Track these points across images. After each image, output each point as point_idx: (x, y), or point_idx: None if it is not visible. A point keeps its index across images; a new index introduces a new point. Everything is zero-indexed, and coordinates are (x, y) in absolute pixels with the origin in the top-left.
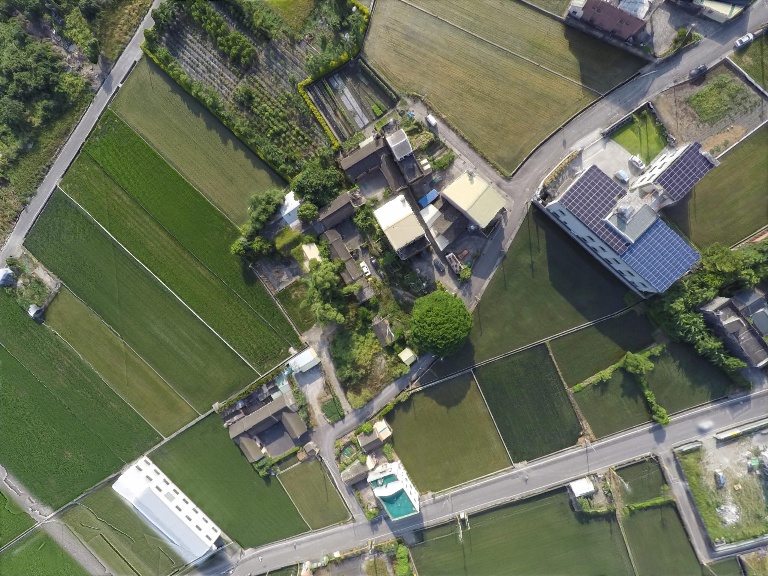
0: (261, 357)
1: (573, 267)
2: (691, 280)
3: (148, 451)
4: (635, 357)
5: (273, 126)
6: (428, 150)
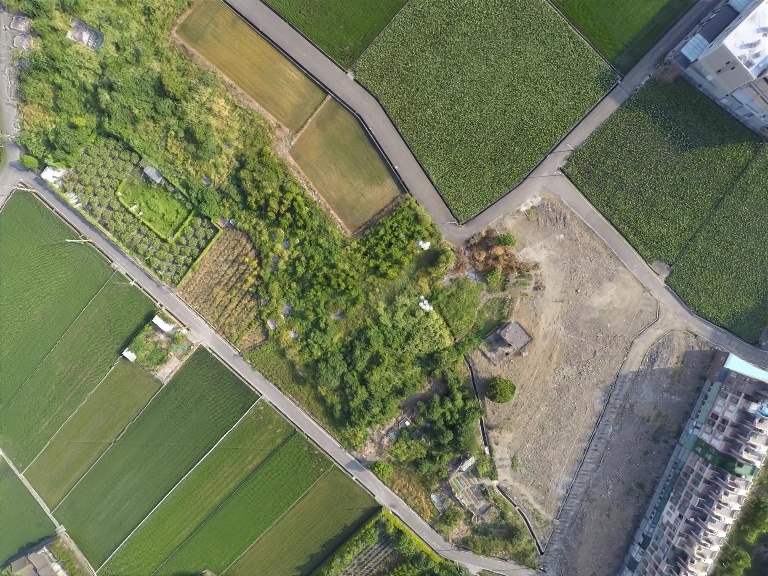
0: (113, 575)
1: None
2: None
3: (5, 456)
4: None
5: None
6: None
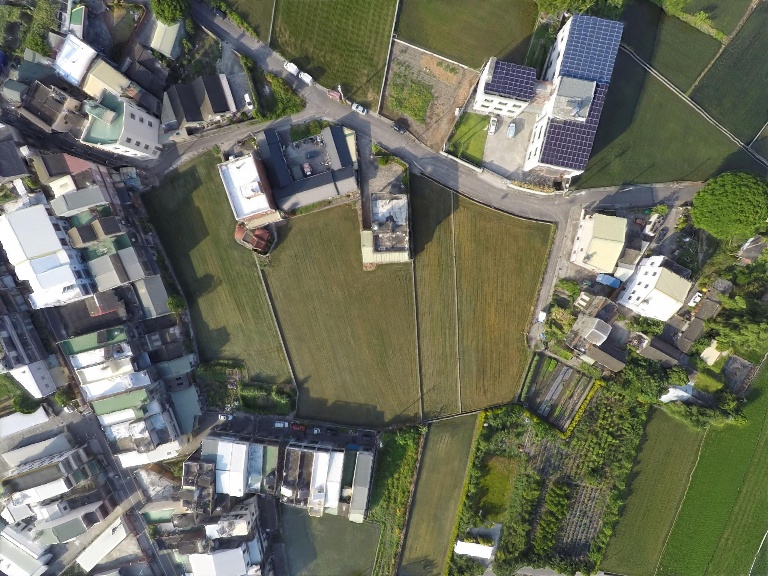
0: None
1: (604, 119)
2: (580, 6)
3: None
4: (672, 4)
5: (608, 442)
6: (565, 305)
